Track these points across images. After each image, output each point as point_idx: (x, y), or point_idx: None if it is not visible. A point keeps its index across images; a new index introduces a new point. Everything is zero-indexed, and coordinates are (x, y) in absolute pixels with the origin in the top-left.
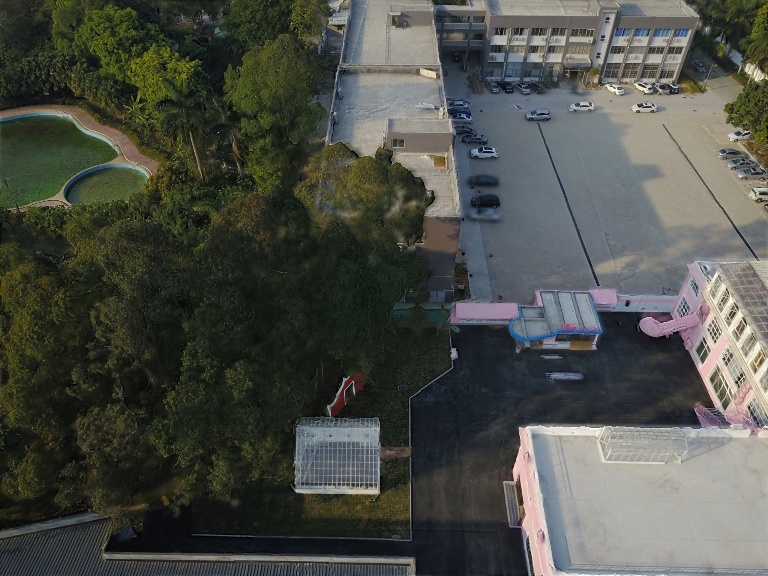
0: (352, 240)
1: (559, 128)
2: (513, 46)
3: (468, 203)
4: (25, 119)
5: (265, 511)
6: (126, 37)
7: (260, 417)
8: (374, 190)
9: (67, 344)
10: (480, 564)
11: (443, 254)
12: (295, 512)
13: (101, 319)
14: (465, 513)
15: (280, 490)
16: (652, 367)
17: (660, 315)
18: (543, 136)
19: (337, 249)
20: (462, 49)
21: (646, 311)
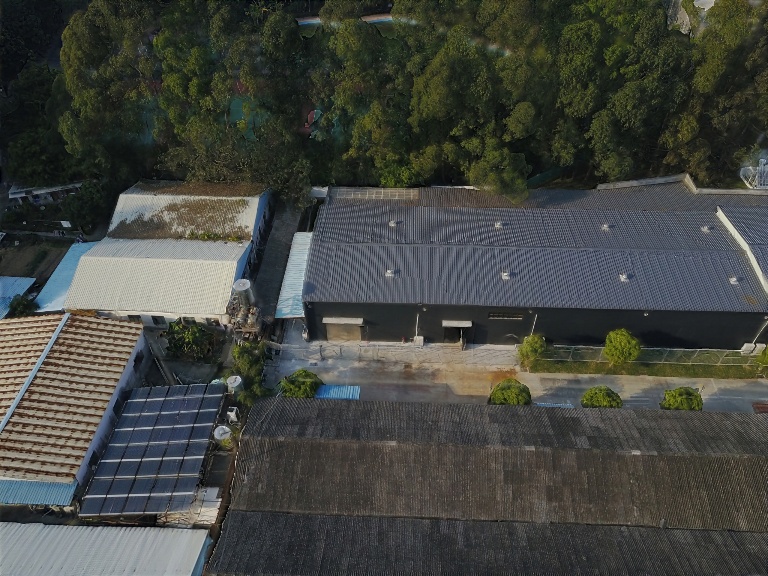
0: None
1: None
2: None
3: None
4: (380, 23)
5: None
6: None
7: None
8: None
9: None
10: None
11: None
12: None
13: None
14: None
15: None
16: None
17: None
18: None
19: None
20: None
21: None
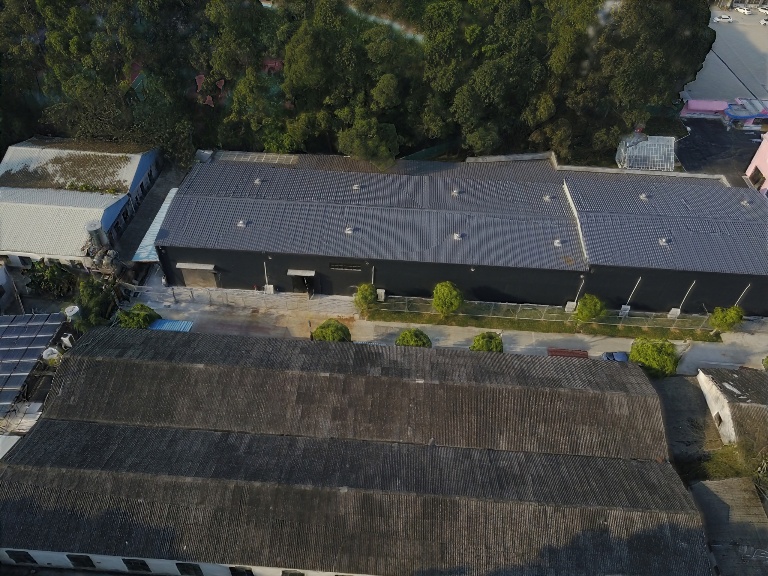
0: None
1: None
2: None
3: None
4: None
5: None
6: None
7: (665, 81)
8: None
9: None
10: None
11: None
12: None
13: (618, 10)
14: None
15: None
16: None
17: None
18: None
19: (696, 6)
20: None
21: None
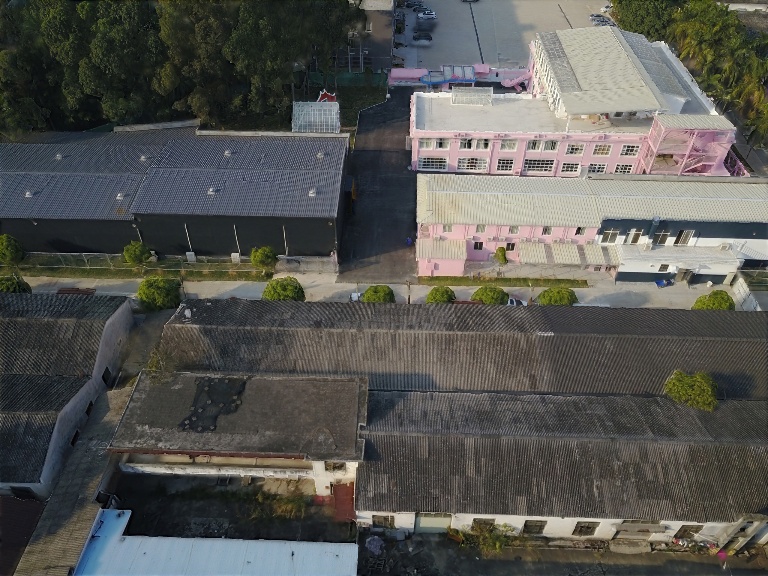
0: None
1: (484, 6)
2: None
3: (411, 38)
4: None
5: None
6: None
7: (275, 46)
8: None
9: (187, 5)
10: (387, 159)
11: (384, 40)
12: None
13: None
14: (383, 146)
15: None
16: None
17: None
18: (471, 10)
19: None
20: None
21: None
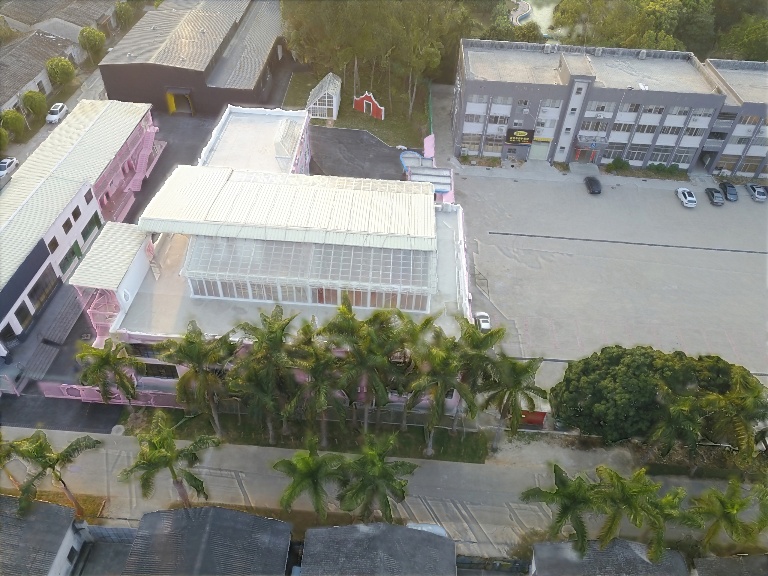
0: None
1: None
2: None
3: None
4: None
5: (303, 90)
6: None
7: None
8: None
9: None
10: None
11: None
12: (301, 97)
13: None
14: None
15: None
16: None
17: None
18: (765, 253)
19: None
20: None
21: None
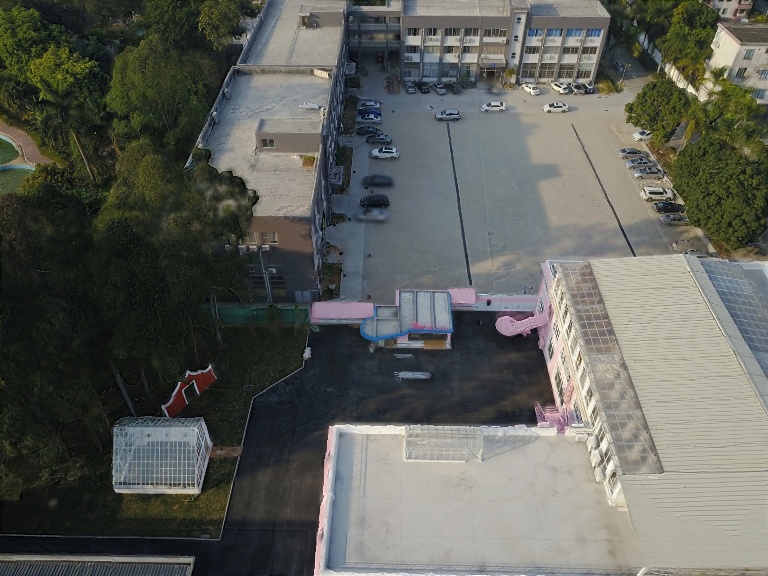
0: (132, 239)
1: (467, 128)
2: (428, 46)
3: (357, 203)
4: None
5: (81, 511)
6: (25, 38)
7: (18, 416)
8: (159, 189)
9: None
10: (282, 563)
11: (300, 254)
12: (111, 512)
13: None
14: (280, 512)
15: (101, 490)
16: (502, 366)
17: (522, 314)
18: (450, 136)
19: (109, 248)
20: (381, 49)
21: (509, 310)
